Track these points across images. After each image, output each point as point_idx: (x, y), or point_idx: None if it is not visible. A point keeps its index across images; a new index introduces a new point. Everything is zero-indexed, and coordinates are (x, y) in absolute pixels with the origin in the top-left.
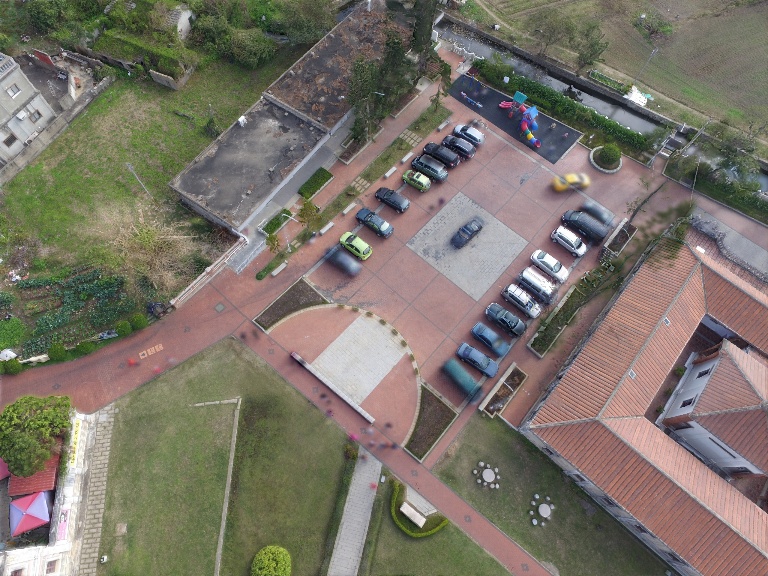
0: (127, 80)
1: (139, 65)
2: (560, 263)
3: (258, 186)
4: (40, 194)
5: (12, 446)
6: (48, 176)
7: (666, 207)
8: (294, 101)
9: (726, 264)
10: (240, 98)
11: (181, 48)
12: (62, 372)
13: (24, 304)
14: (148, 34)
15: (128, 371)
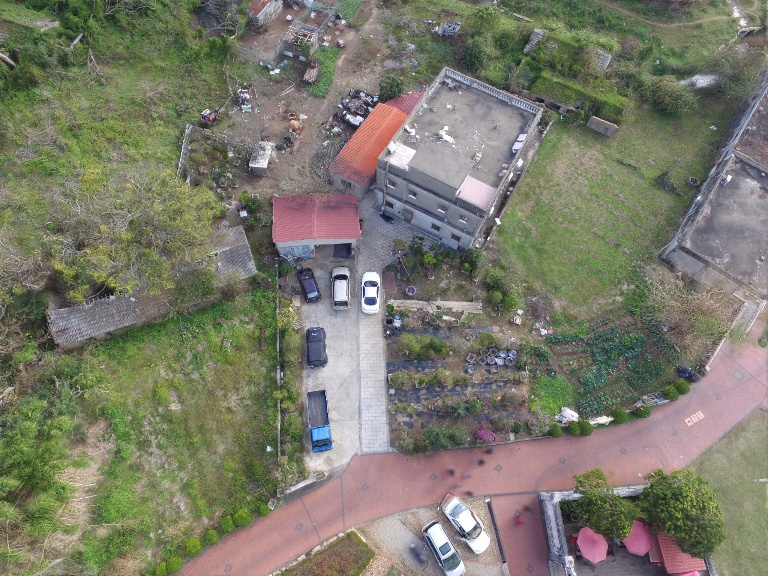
0: (561, 124)
1: (582, 111)
2: None
3: (767, 252)
4: (530, 243)
5: (698, 527)
6: (529, 223)
7: None
8: (763, 160)
9: None
10: (673, 149)
11: (616, 94)
12: (623, 435)
13: (560, 360)
14: (582, 78)
15: (682, 439)
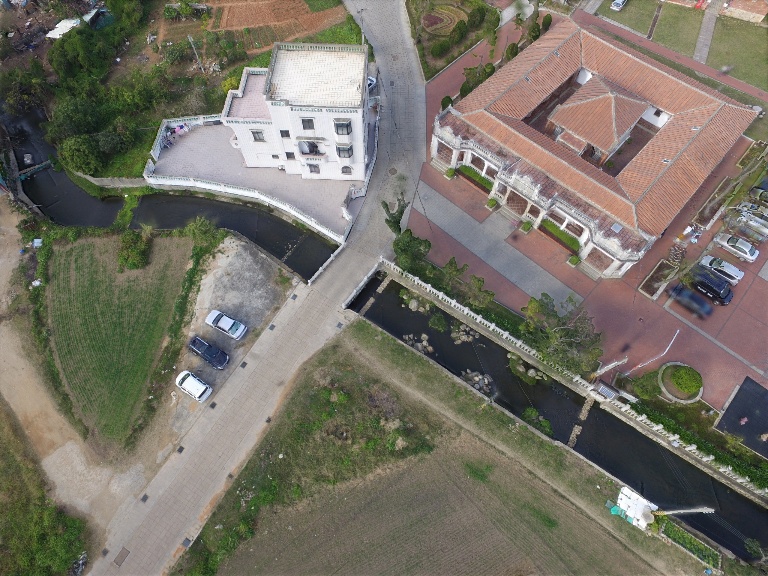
0: None
1: None
2: (731, 245)
3: None
4: None
5: None
6: None
7: (600, 318)
8: None
9: (591, 215)
10: None
11: None
12: None
13: None
14: None
15: None
